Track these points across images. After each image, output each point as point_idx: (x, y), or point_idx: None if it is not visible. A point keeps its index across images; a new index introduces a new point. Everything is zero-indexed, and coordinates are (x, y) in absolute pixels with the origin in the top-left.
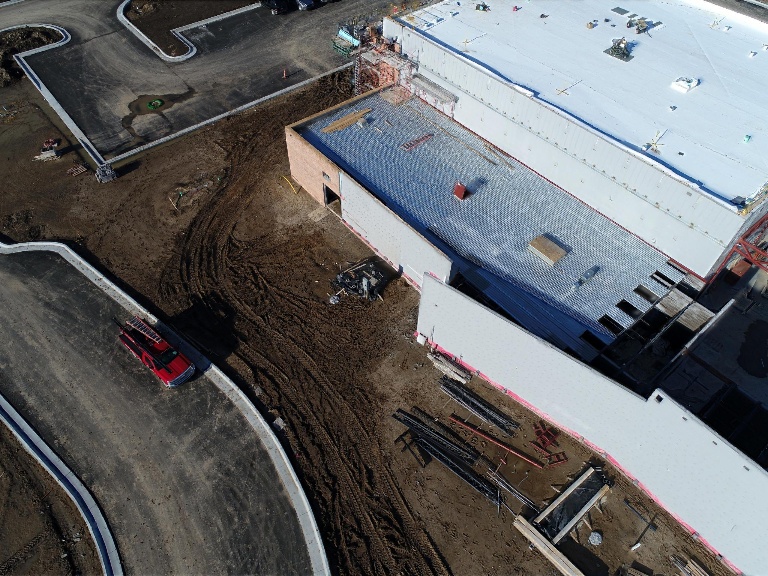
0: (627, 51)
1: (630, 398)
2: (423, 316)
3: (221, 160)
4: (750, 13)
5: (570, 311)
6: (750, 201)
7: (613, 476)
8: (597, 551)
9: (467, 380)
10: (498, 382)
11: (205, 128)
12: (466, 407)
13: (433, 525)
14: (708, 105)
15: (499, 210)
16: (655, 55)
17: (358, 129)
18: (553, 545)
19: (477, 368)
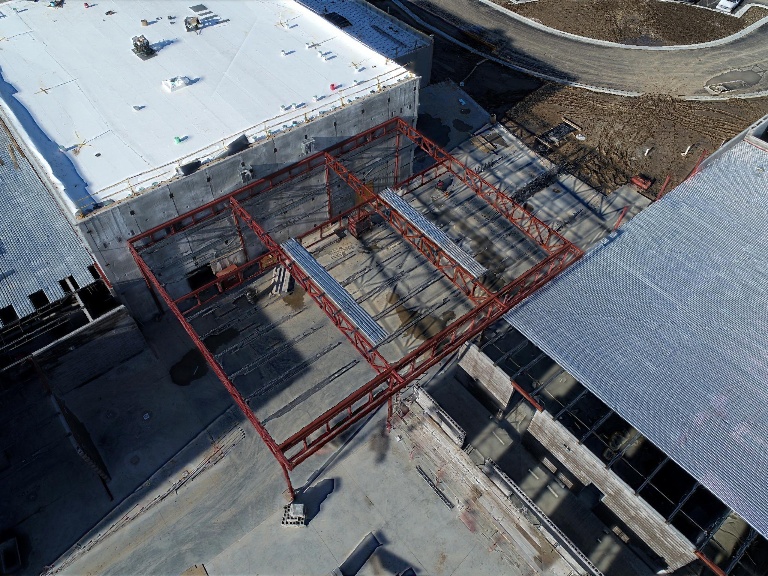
0: (147, 49)
1: None
2: None
3: None
4: (471, 12)
5: None
6: (107, 204)
7: None
8: None
9: None
10: None
11: None
12: None
13: None
14: (181, 105)
15: None
16: (181, 53)
17: None
18: None
19: None
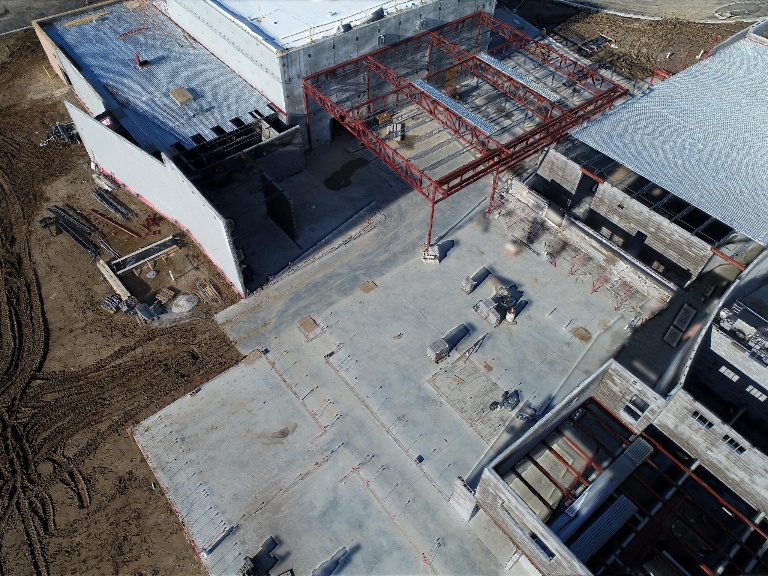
0: None
1: (161, 167)
2: (85, 143)
3: (4, 57)
4: None
5: (174, 131)
6: (294, 47)
7: (187, 243)
8: (149, 281)
9: (114, 190)
10: (133, 189)
11: (4, 37)
12: (104, 204)
13: (42, 267)
14: None
15: (165, 74)
16: None
17: (92, 25)
18: (115, 274)
19: (122, 181)
